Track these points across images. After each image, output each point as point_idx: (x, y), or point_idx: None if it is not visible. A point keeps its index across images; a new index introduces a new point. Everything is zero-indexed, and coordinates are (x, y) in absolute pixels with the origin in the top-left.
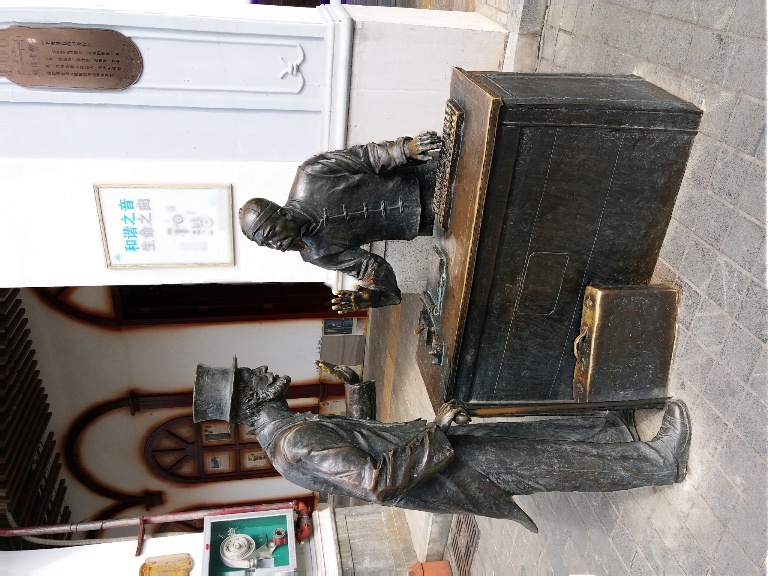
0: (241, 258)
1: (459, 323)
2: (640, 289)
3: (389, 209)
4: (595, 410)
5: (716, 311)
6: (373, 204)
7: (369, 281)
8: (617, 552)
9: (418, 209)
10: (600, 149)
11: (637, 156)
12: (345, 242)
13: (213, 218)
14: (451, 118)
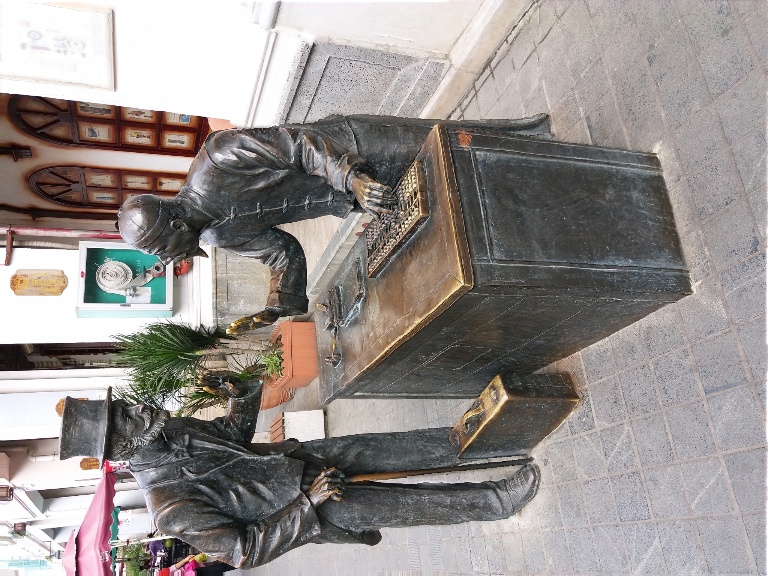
0: (124, 86)
1: (360, 374)
2: (545, 397)
3: (315, 202)
4: (470, 397)
5: (600, 453)
6: (296, 199)
7: (274, 293)
8: None
9: (350, 206)
10: (566, 306)
11: (602, 310)
12: (254, 233)
13: (85, 41)
14: (413, 193)
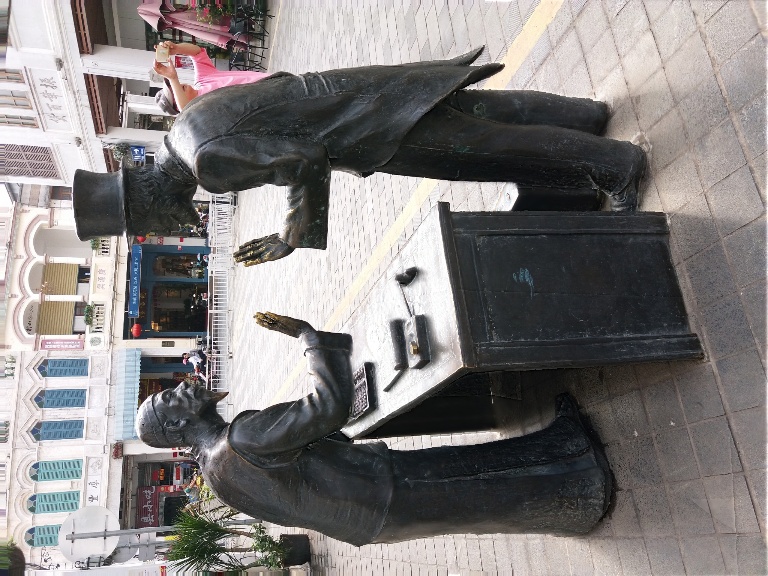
0: None
1: None
2: None
3: None
4: None
5: None
6: None
7: None
8: (756, 15)
9: None
10: None
11: None
12: None
13: None
14: None
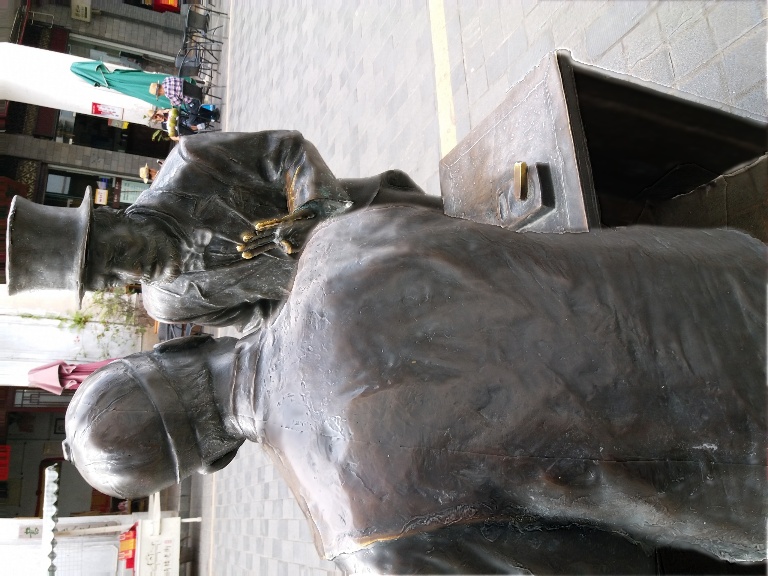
0: None
1: None
2: None
3: None
4: None
5: None
6: None
7: None
8: None
9: None
10: None
11: None
12: None
13: None
14: None
